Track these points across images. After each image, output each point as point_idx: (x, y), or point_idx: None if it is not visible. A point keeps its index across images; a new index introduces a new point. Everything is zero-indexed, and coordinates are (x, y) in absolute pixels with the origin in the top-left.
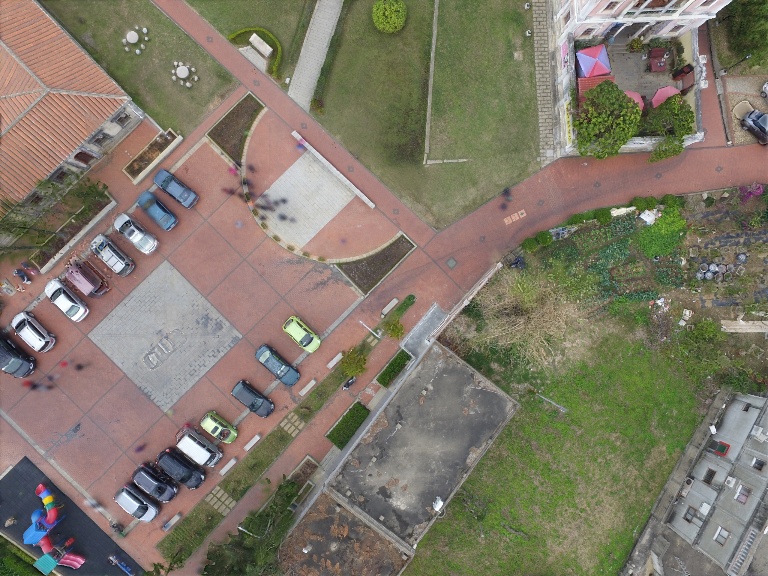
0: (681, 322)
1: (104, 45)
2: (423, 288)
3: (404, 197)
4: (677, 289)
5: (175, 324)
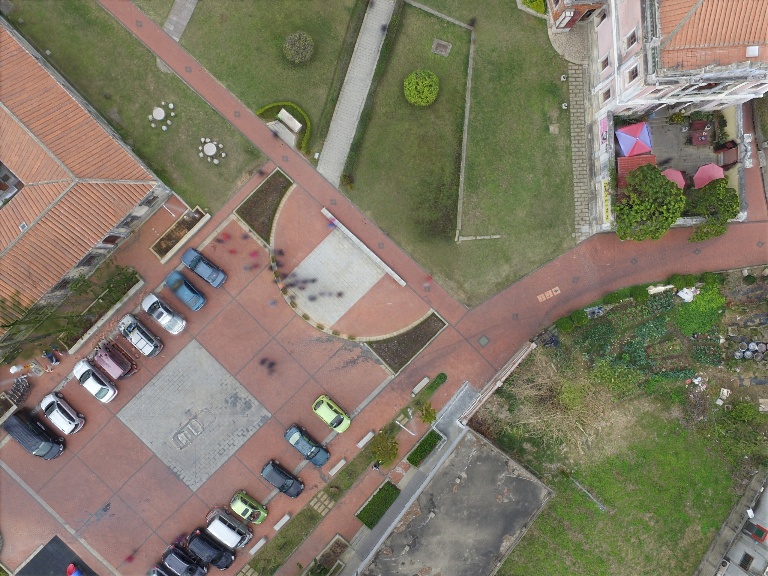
0: (718, 401)
1: (130, 121)
2: (454, 366)
3: (435, 274)
4: (715, 368)
5: (204, 403)
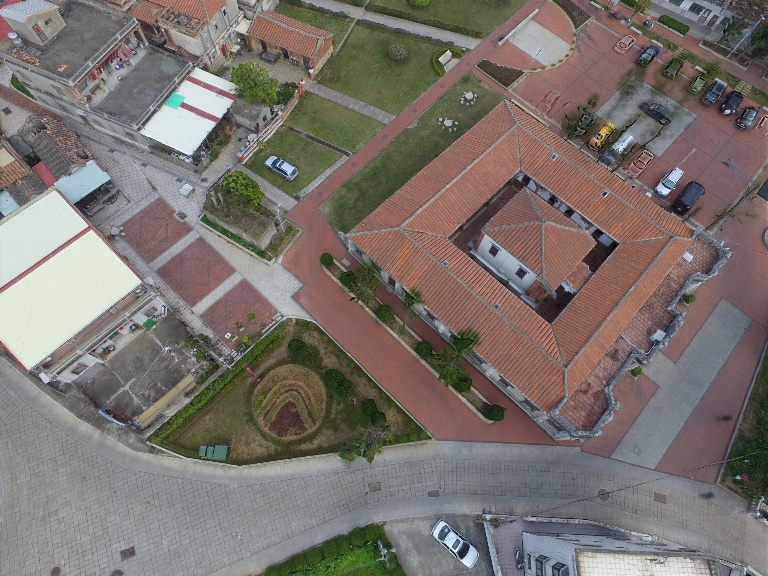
0: None
1: None
2: None
3: None
4: None
5: (636, 109)
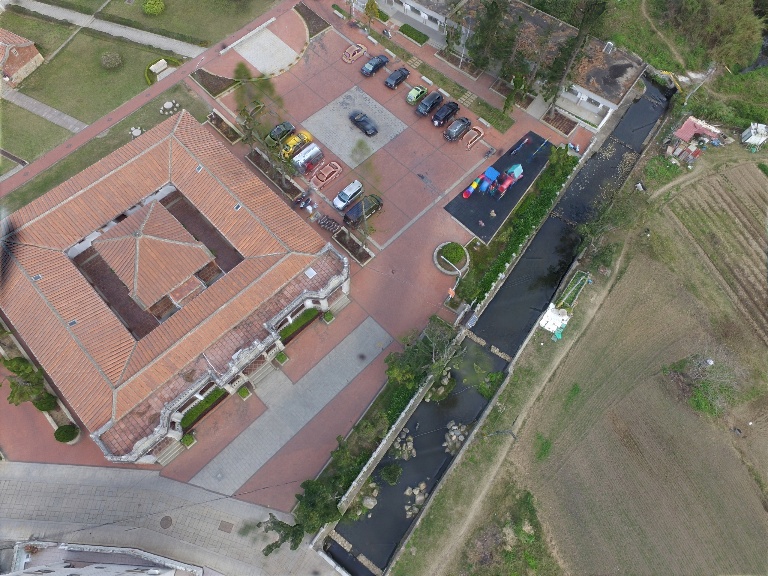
0: None
1: None
2: (328, 1)
3: (270, 7)
4: None
5: (346, 120)
